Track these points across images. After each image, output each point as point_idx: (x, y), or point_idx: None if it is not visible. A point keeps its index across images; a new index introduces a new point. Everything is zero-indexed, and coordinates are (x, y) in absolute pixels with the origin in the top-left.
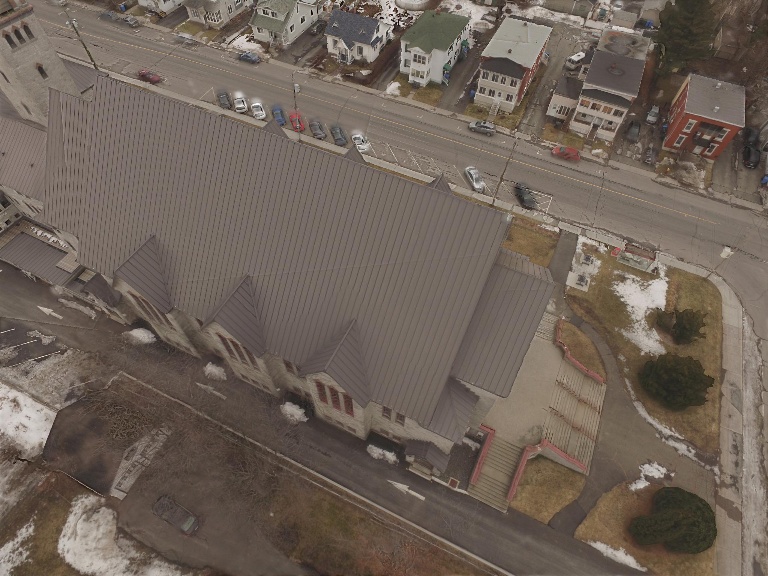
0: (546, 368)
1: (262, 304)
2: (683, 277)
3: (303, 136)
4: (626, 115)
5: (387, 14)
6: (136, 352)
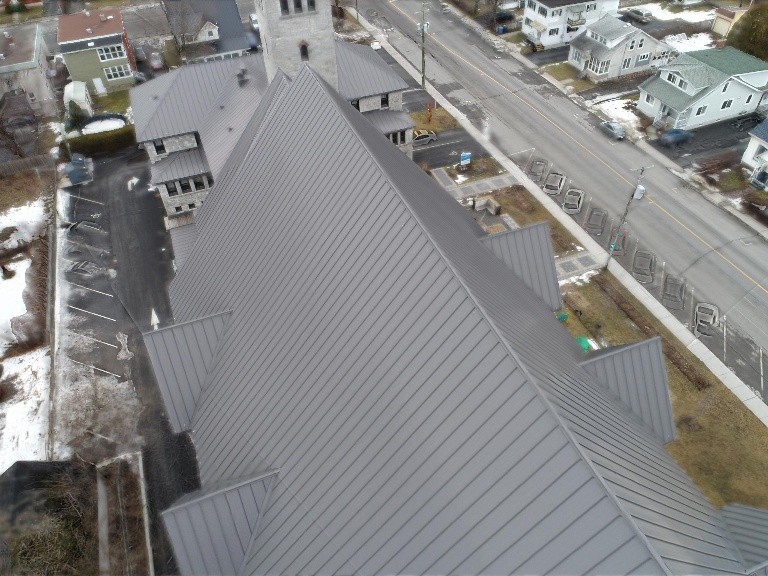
0: None
1: (264, 541)
2: None
3: (615, 264)
4: None
5: None
6: (176, 438)
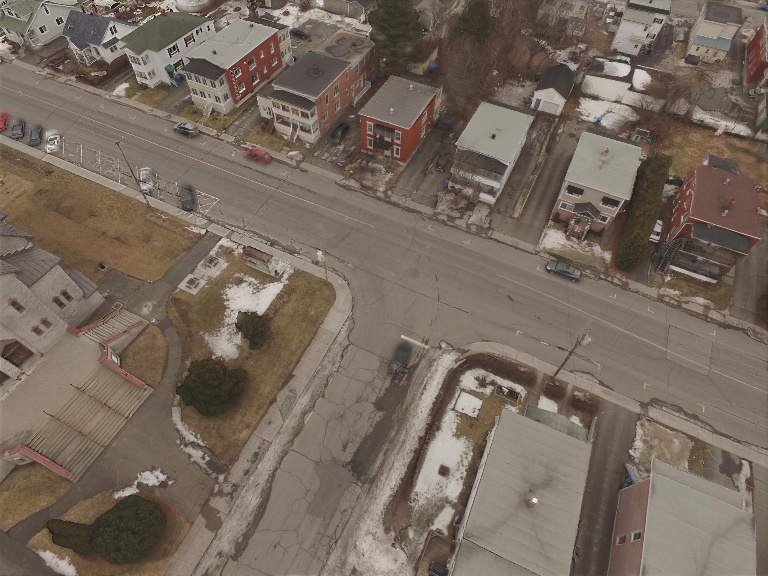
0: (77, 372)
1: None
2: (305, 281)
3: None
4: (344, 117)
5: None
6: None
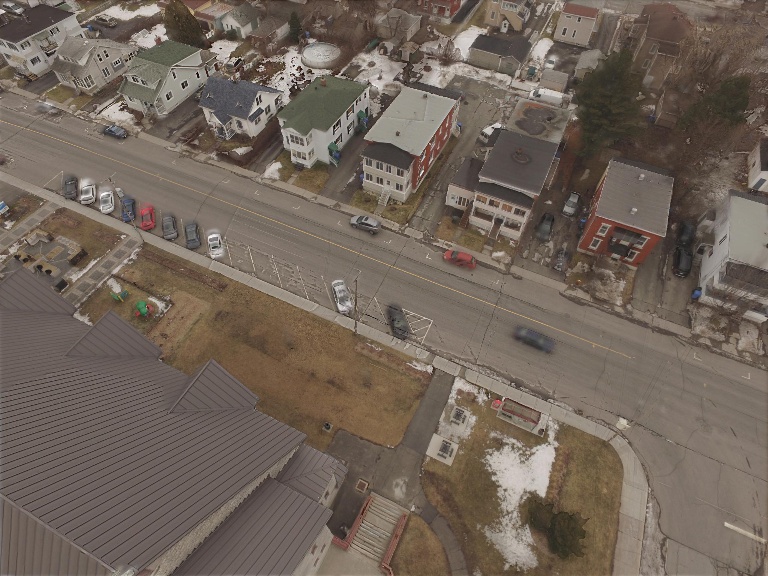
0: None
1: None
2: (577, 441)
3: (150, 236)
4: (541, 204)
5: (289, 73)
6: None
